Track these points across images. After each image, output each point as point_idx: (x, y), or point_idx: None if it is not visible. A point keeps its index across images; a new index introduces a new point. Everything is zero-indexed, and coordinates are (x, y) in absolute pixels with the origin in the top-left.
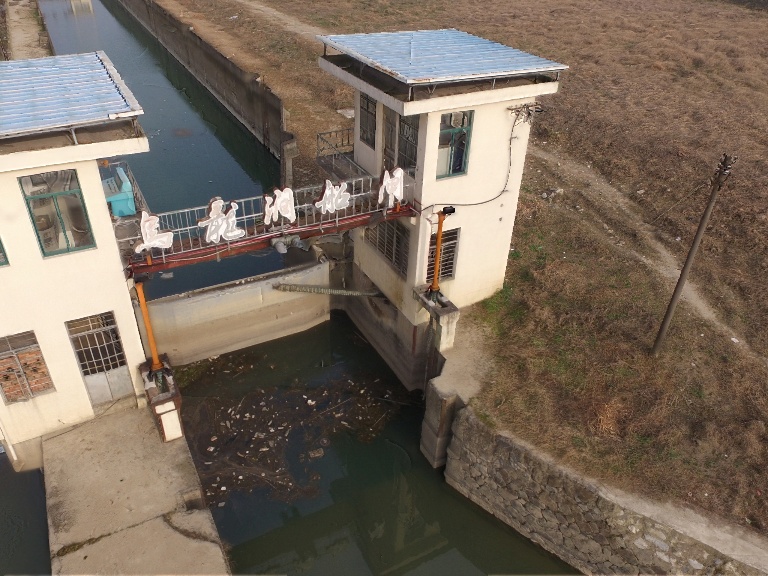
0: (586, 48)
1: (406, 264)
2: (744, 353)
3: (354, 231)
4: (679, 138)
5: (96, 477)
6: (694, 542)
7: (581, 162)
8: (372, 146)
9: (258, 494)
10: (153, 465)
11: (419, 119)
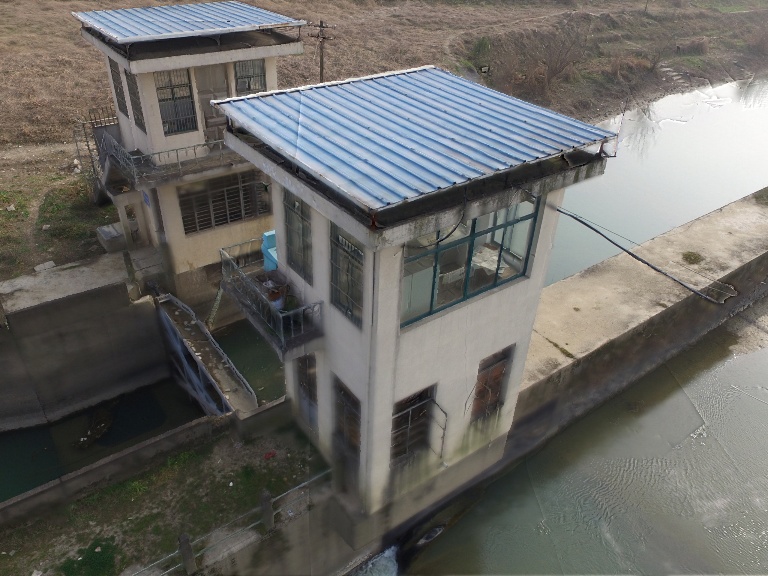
0: None
1: (262, 203)
2: None
3: (174, 241)
4: (2, 99)
5: None
6: None
7: (6, 148)
8: (193, 129)
9: None
10: None
11: (265, 64)
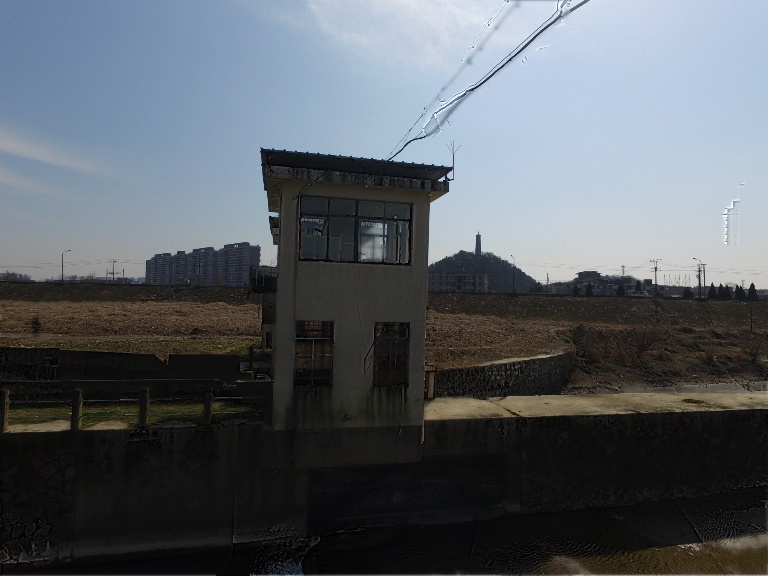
0: (99, 312)
1: None
2: None
3: None
4: None
5: (460, 409)
6: (500, 365)
7: None
8: None
9: None
10: (453, 401)
11: None
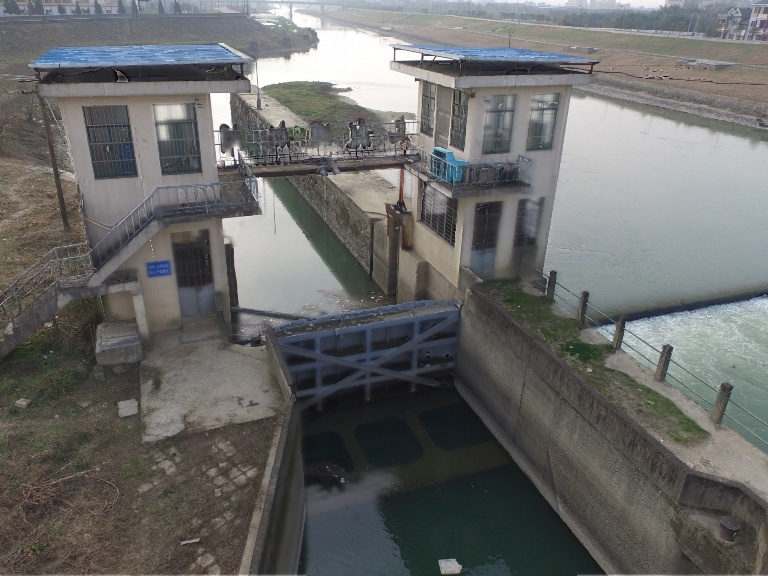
0: None
1: None
2: (0, 230)
3: None
4: None
5: None
6: None
7: None
8: None
9: (351, 294)
10: None
11: None
